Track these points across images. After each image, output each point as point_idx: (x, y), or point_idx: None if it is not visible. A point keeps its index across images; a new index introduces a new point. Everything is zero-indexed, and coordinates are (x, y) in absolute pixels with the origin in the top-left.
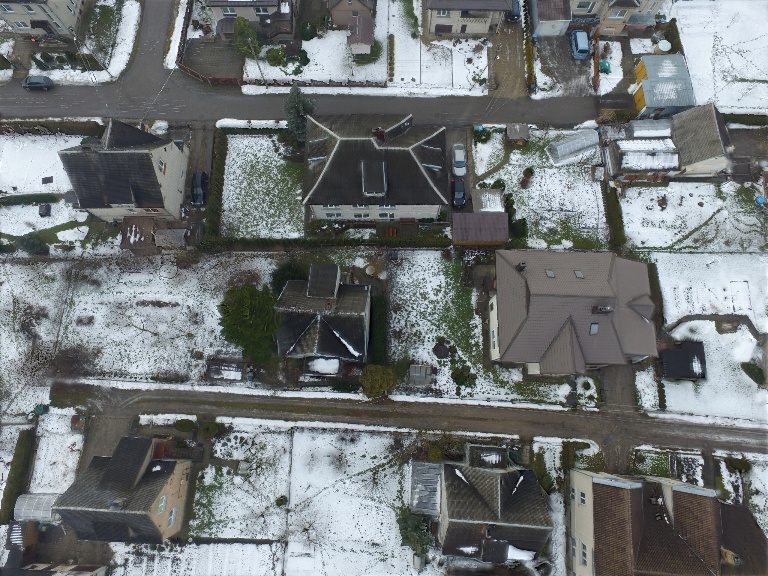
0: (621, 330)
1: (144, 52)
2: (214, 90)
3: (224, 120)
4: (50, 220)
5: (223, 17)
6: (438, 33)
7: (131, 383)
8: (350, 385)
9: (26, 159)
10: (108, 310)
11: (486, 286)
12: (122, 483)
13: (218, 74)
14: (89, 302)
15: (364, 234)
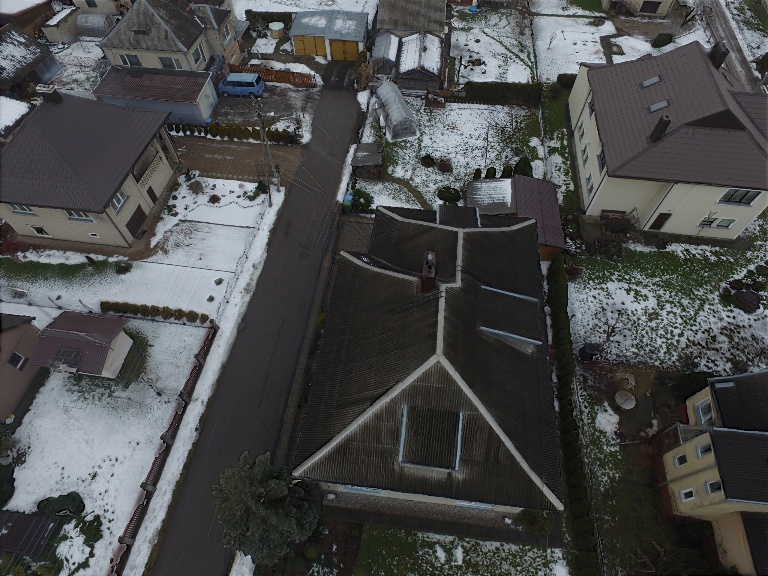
0: None
1: None
2: None
3: None
4: None
5: None
6: (137, 235)
7: None
8: None
9: None
10: None
11: (624, 226)
12: None
13: None
14: None
15: None
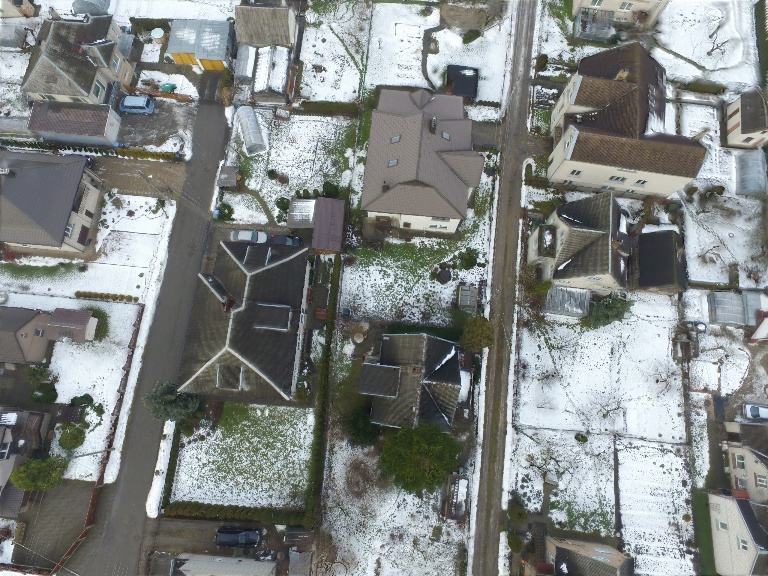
0: (445, 117)
1: None
2: (101, 521)
3: (148, 506)
4: None
5: None
6: (86, 243)
7: None
8: (473, 366)
9: None
10: None
11: (386, 228)
12: None
13: (78, 516)
14: None
15: (318, 342)
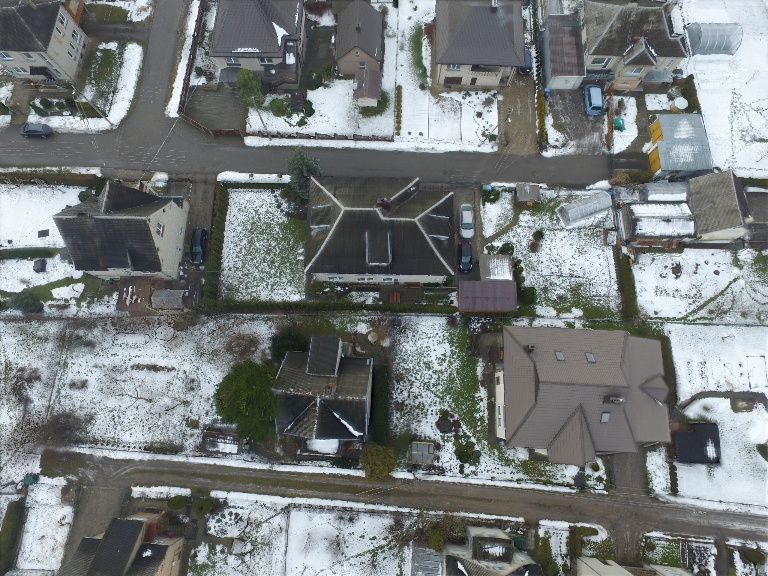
0: (633, 417)
1: (145, 99)
2: (216, 141)
3: (226, 173)
4: (45, 276)
5: (227, 66)
6: (447, 84)
7: (124, 452)
8: (350, 460)
9: (22, 210)
10: (102, 373)
11: (492, 357)
12: (111, 573)
13: (220, 124)
14: (83, 364)
15: (367, 298)
